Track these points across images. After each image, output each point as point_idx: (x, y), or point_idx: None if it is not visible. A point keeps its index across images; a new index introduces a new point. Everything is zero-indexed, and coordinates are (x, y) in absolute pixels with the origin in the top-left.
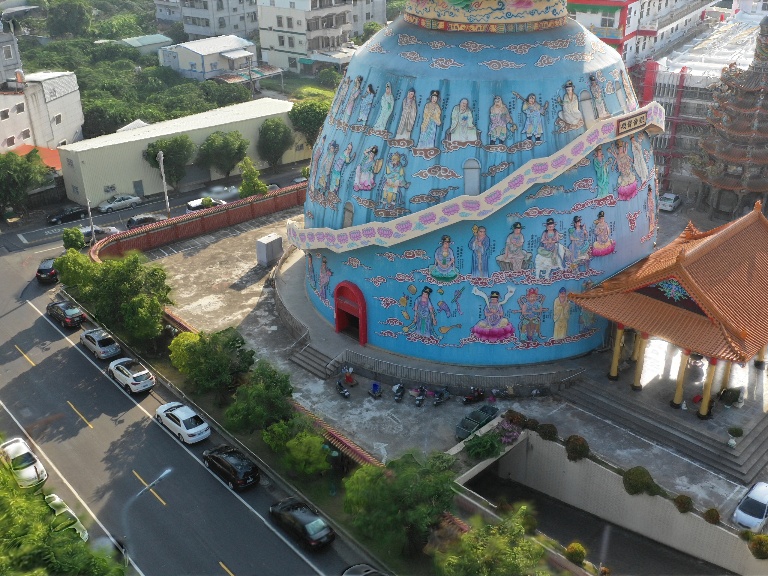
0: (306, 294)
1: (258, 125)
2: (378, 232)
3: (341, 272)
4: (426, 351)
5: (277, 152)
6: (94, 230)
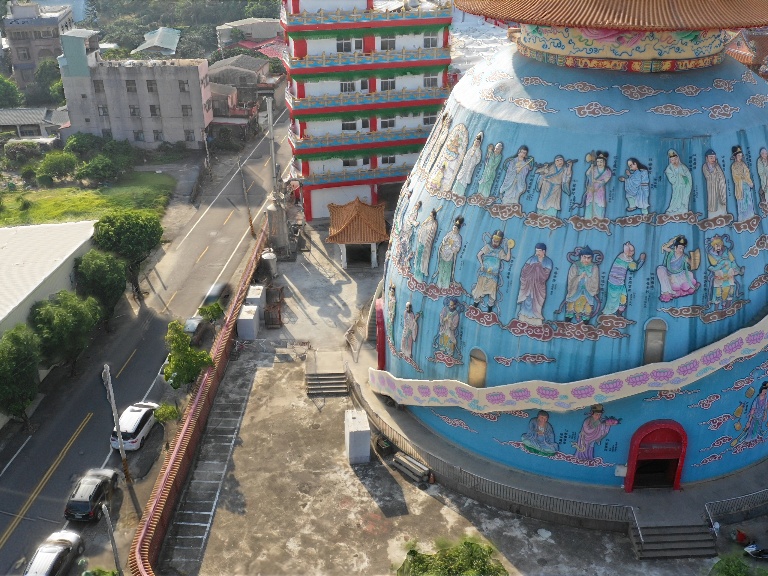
0: (506, 467)
1: (67, 272)
2: (747, 341)
3: (642, 413)
4: (749, 456)
5: (114, 301)
6: (56, 557)
